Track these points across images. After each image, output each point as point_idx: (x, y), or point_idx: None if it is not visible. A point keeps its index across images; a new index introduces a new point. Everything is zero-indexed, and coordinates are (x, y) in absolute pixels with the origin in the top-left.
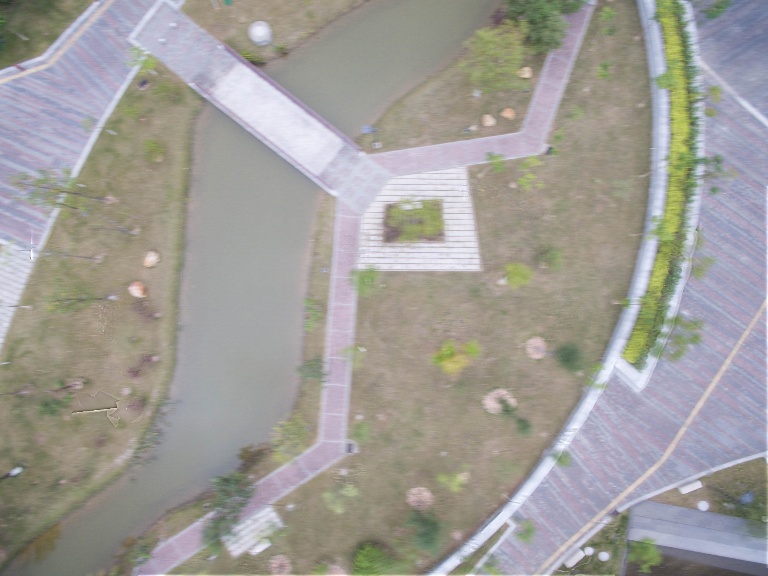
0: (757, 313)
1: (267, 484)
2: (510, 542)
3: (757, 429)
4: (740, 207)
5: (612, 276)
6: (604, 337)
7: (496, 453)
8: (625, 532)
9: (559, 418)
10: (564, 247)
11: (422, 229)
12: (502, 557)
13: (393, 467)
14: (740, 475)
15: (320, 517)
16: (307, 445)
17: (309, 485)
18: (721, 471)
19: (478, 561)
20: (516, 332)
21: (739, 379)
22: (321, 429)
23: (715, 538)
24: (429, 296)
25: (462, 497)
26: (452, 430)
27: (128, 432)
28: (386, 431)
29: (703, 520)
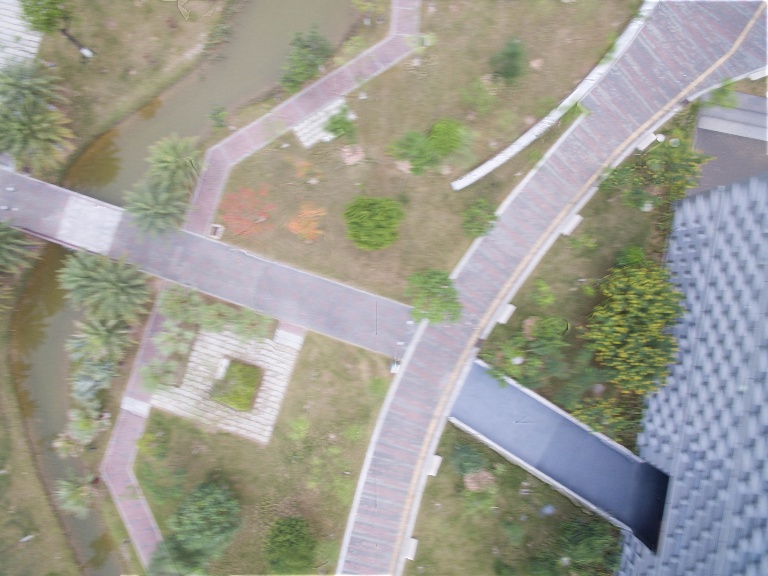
0: None
1: (340, 76)
2: (583, 128)
3: None
4: None
5: None
6: None
7: (569, 41)
8: (695, 120)
9: (631, 7)
10: None
11: None
12: (575, 143)
13: (467, 54)
14: None
15: (394, 106)
16: (380, 38)
17: (382, 76)
18: None
19: (552, 145)
20: None
21: None
22: (394, 22)
23: None
24: None
25: (536, 84)
26: (526, 18)
27: (199, 26)
28: (460, 20)
29: None
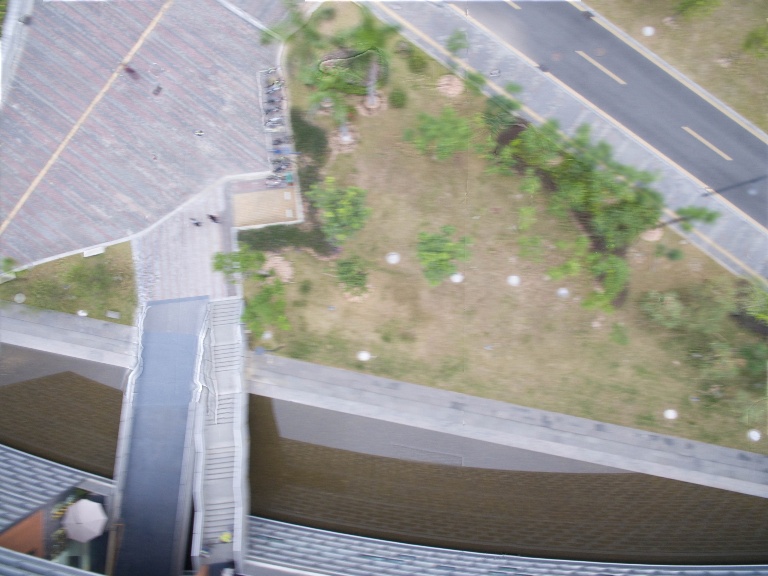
0: (88, 108)
1: None
2: None
3: (82, 224)
4: (76, 2)
5: None
6: None
7: None
8: None
9: None
10: None
11: None
12: None
13: None
14: (60, 269)
15: None
16: None
17: None
18: (42, 265)
19: None
20: None
21: (66, 174)
22: None
23: (31, 331)
24: None
25: None
26: None
27: None
28: None
29: (18, 312)
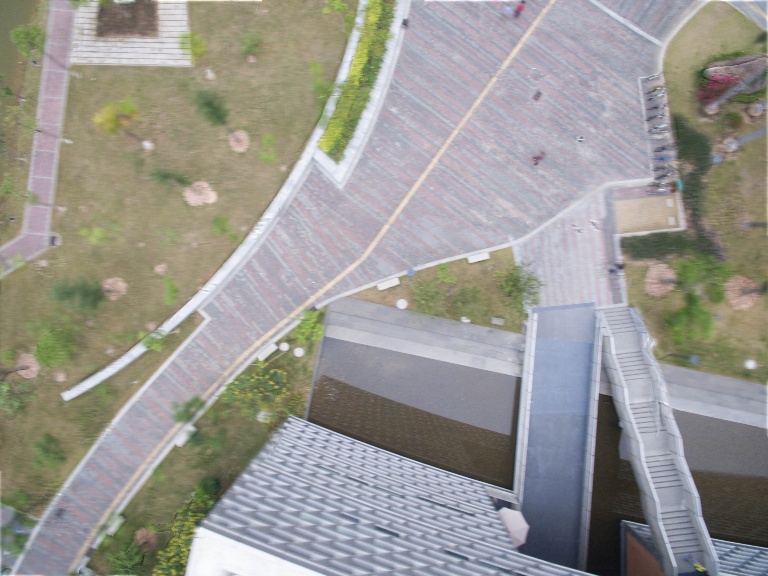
0: (467, 113)
1: None
2: (205, 335)
3: (462, 230)
4: (454, 5)
5: (320, 71)
6: (307, 131)
7: (195, 246)
8: (322, 328)
9: (259, 212)
10: (273, 42)
11: (135, 23)
12: (197, 350)
13: (92, 258)
14: (442, 275)
15: (19, 307)
16: (11, 236)
17: (11, 276)
18: (423, 270)
19: (172, 353)
20: (220, 125)
21: (446, 179)
22: (26, 221)
23: (413, 337)
24: (137, 89)
25: (159, 289)
26: (151, 221)
27: None
28: (87, 222)
29: (401, 318)
